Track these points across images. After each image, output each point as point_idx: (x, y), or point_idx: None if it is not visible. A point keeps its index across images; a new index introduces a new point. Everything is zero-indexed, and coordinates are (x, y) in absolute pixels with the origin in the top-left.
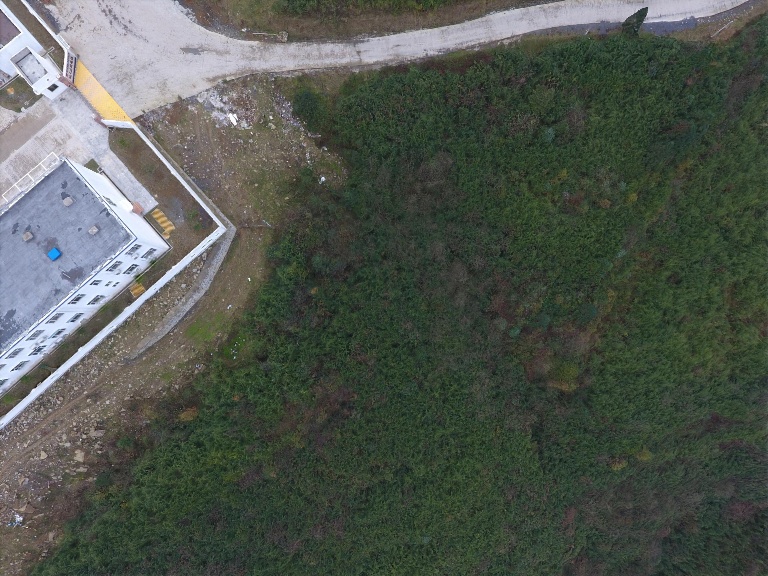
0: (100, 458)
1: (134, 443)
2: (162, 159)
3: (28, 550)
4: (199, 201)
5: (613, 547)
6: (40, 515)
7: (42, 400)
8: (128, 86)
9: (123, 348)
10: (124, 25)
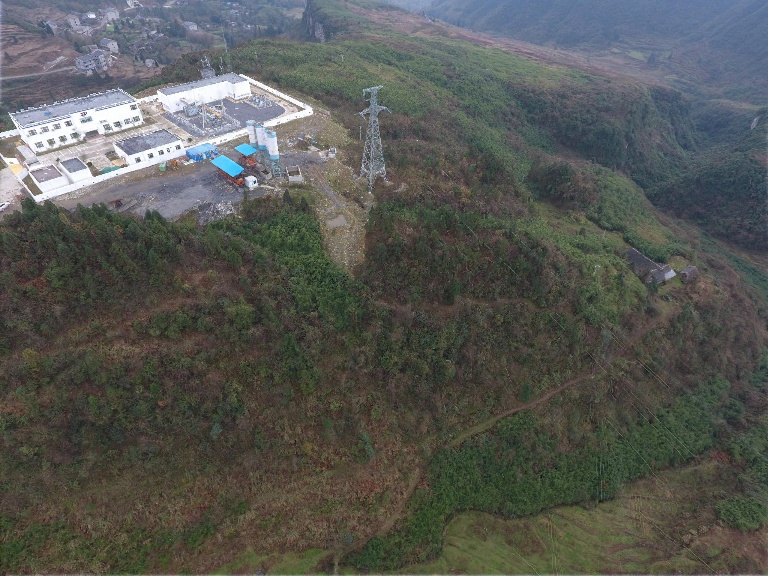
0: None
1: None
2: None
3: None
4: None
5: None
6: None
7: None
8: (2, 176)
9: None
10: None
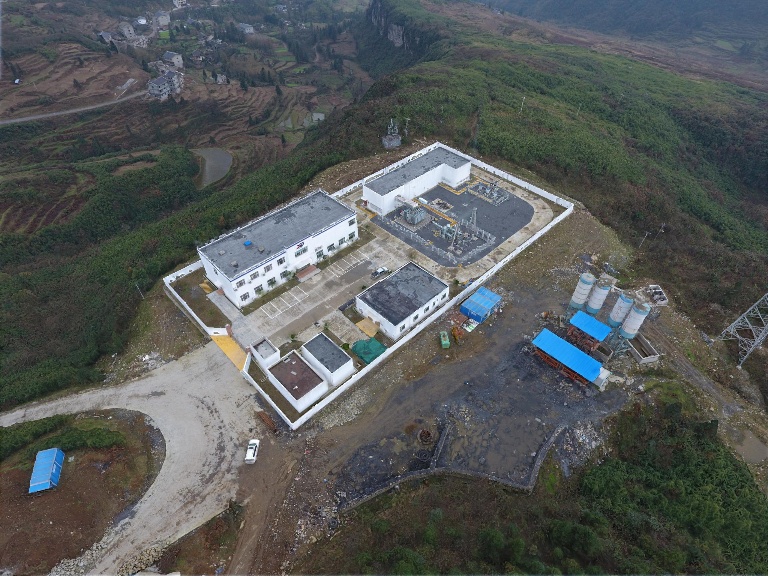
0: None
1: None
2: (190, 309)
3: None
4: (173, 290)
5: (65, 259)
6: None
7: None
8: (211, 362)
9: None
10: (204, 404)
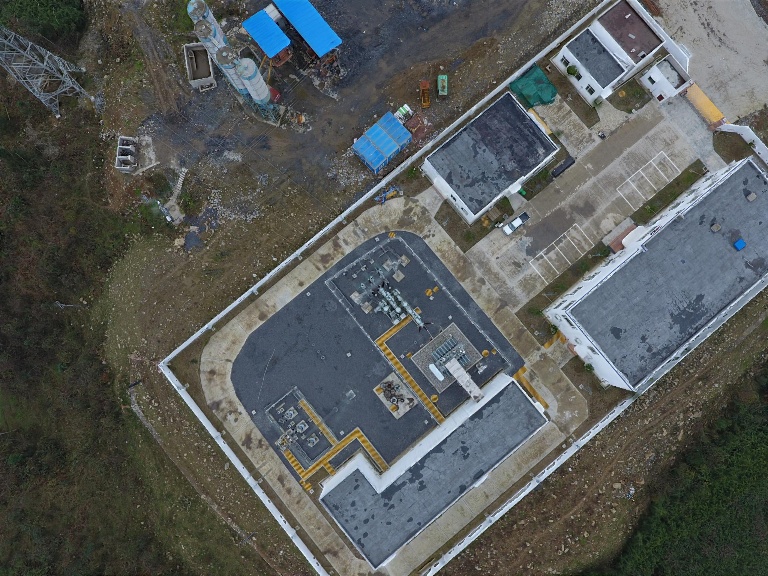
0: (685, 438)
1: (707, 426)
2: None
3: (624, 522)
4: None
5: None
6: (640, 489)
7: (658, 381)
8: (724, 93)
9: (731, 335)
10: (719, 37)
